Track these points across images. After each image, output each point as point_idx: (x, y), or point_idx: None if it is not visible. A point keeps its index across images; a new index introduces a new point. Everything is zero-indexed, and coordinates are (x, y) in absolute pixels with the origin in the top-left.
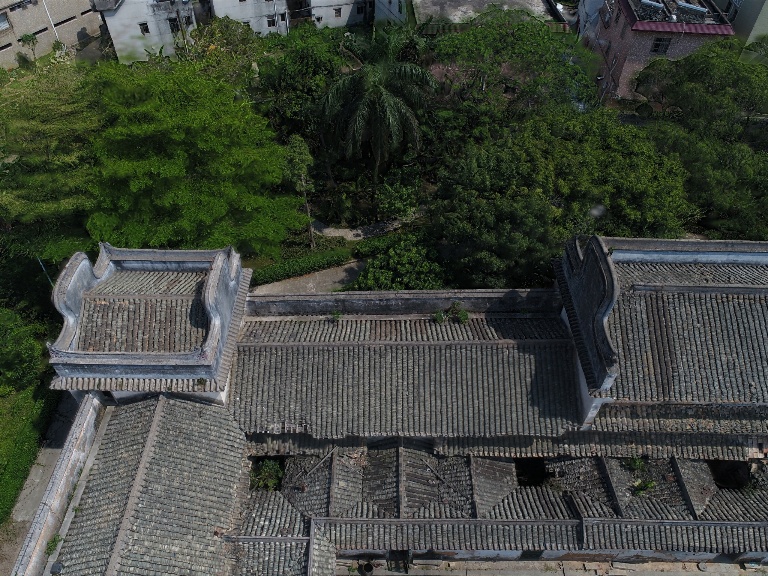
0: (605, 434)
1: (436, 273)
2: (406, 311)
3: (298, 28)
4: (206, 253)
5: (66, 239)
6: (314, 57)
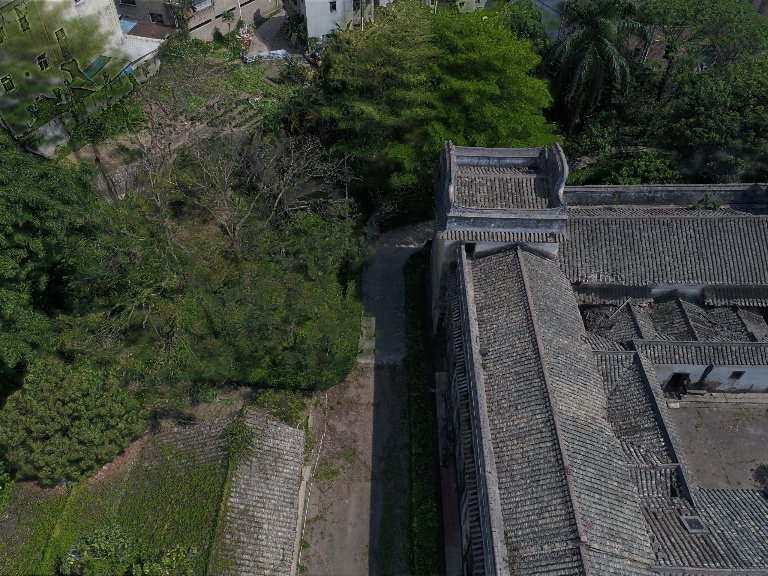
0: None
1: (676, 179)
2: (666, 203)
3: (445, 11)
4: (523, 151)
5: (401, 143)
6: (518, 23)
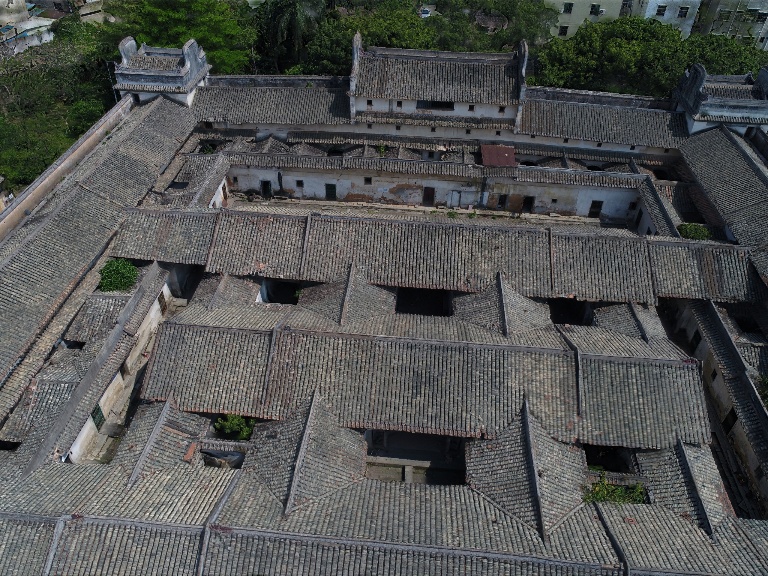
0: (369, 136)
1: None
2: None
3: None
4: None
5: None
6: None
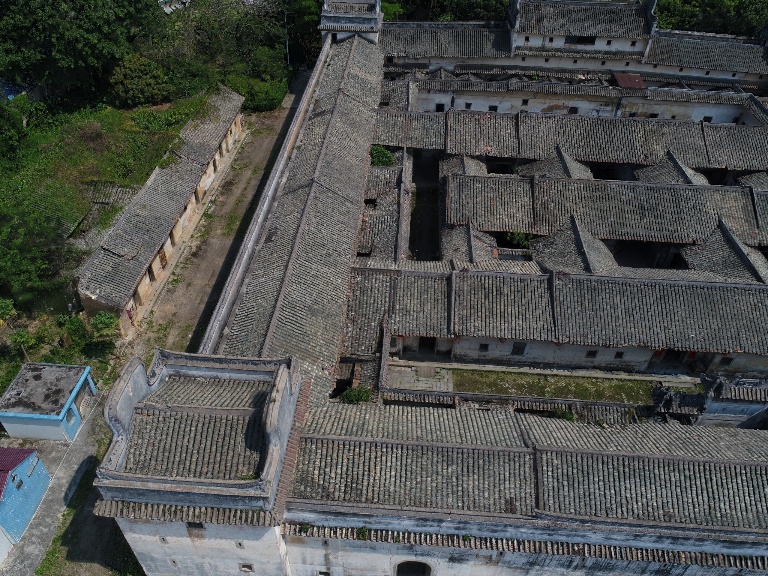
0: (522, 67)
1: None
2: None
3: None
4: (369, 0)
5: None
6: None
